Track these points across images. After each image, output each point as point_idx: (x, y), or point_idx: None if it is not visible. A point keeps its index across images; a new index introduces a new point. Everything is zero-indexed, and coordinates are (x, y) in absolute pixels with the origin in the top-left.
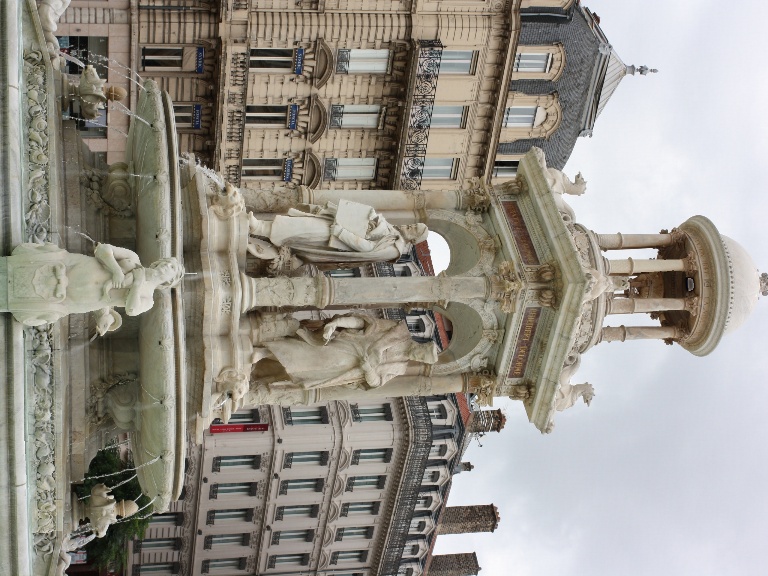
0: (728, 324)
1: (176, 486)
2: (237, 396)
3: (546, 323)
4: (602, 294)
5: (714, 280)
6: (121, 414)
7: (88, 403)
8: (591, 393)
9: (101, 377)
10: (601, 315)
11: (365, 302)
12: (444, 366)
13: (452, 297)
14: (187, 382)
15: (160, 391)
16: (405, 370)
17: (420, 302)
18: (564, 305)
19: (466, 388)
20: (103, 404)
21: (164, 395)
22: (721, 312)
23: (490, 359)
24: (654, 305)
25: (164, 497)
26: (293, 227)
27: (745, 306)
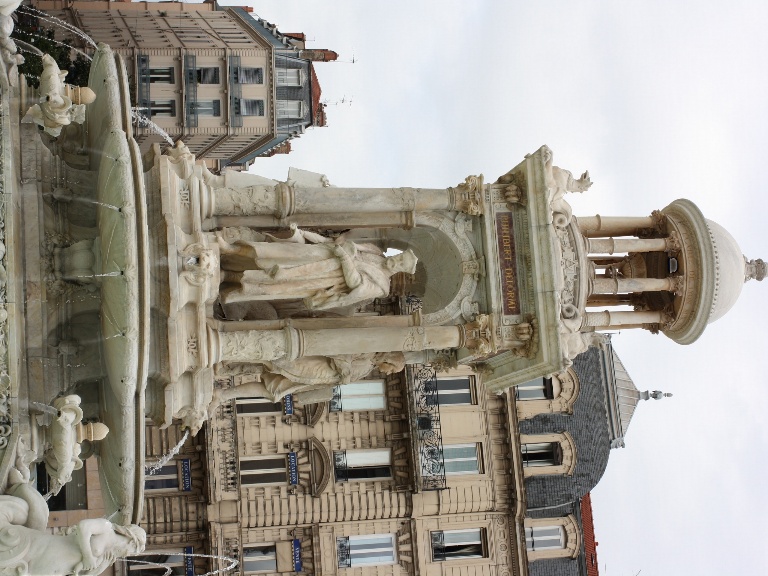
0: (719, 261)
1: (142, 278)
2: (205, 256)
3: (522, 231)
4: (574, 225)
5: (685, 220)
6: (79, 254)
7: (43, 248)
8: (601, 336)
9: (56, 231)
10: (580, 244)
11: (328, 209)
12: (433, 316)
13: (416, 200)
14: (151, 261)
15: (115, 157)
16: (388, 289)
17: (395, 281)
18: (530, 188)
19: (463, 332)
20: (60, 260)
21: (119, 155)
22: (703, 236)
23: (481, 305)
24: (633, 240)
25: (128, 272)
26: (247, 178)
27: (729, 247)
